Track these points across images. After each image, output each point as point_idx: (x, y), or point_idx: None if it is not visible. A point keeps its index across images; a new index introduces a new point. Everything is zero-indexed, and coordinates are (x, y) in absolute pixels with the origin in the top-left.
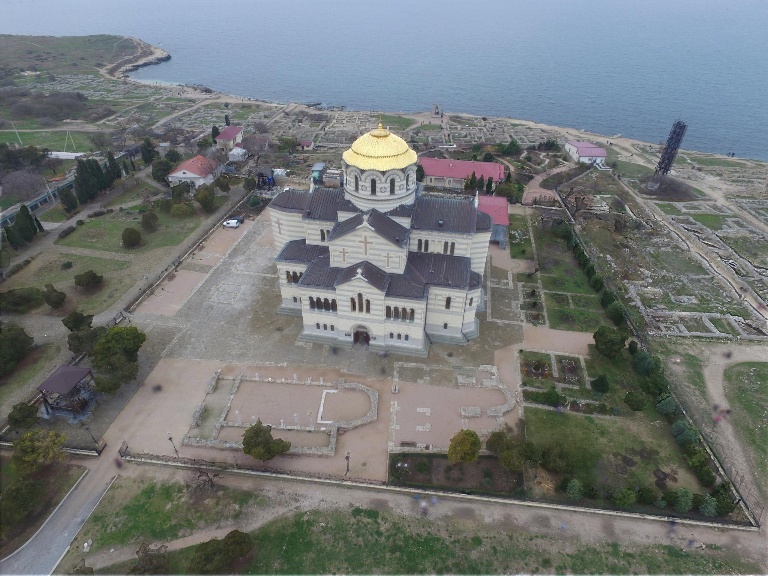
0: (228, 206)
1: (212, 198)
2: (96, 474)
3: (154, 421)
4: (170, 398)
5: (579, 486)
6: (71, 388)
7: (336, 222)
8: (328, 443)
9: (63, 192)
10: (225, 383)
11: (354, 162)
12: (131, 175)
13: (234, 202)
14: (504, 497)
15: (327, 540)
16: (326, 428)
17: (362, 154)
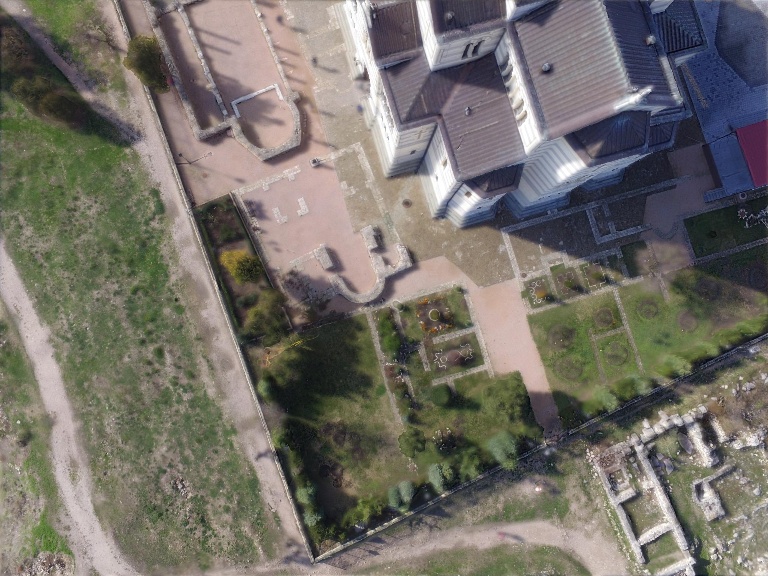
0: None
1: None
2: None
3: None
4: None
5: (262, 391)
6: None
7: None
8: None
9: None
10: None
11: None
12: None
13: None
14: (233, 322)
15: (119, 181)
16: None
17: None
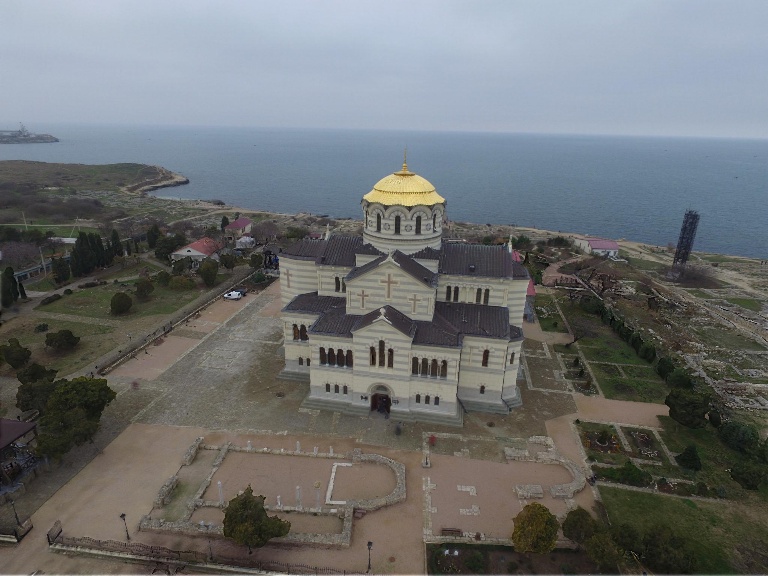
0: (231, 282)
1: (215, 271)
2: (7, 569)
3: (106, 498)
4: (133, 470)
5: None
6: (3, 445)
7: (354, 267)
8: (340, 530)
9: (57, 261)
10: (207, 453)
11: (377, 199)
12: (133, 256)
13: (238, 279)
14: None
15: None
16: (338, 509)
17: (386, 191)
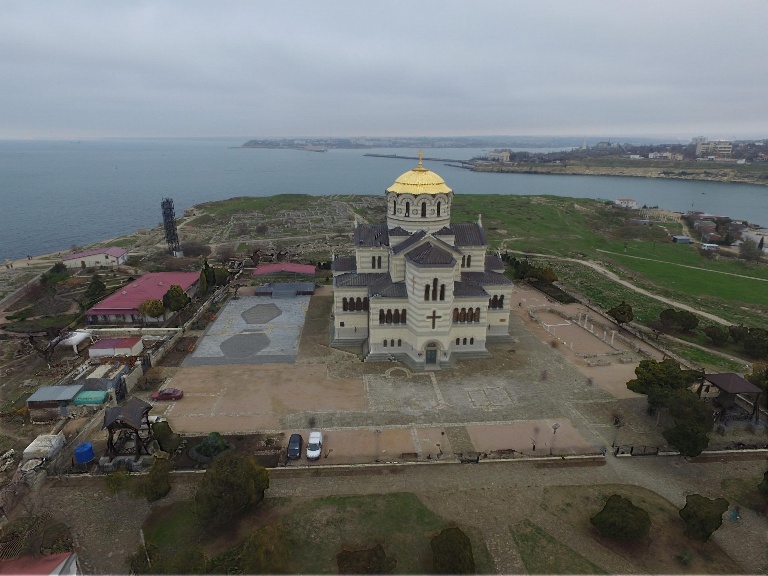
0: None
1: None
2: None
3: None
4: None
5: None
6: None
7: None
8: None
9: None
10: None
11: (446, 190)
12: None
13: (195, 486)
14: None
15: None
16: None
17: None
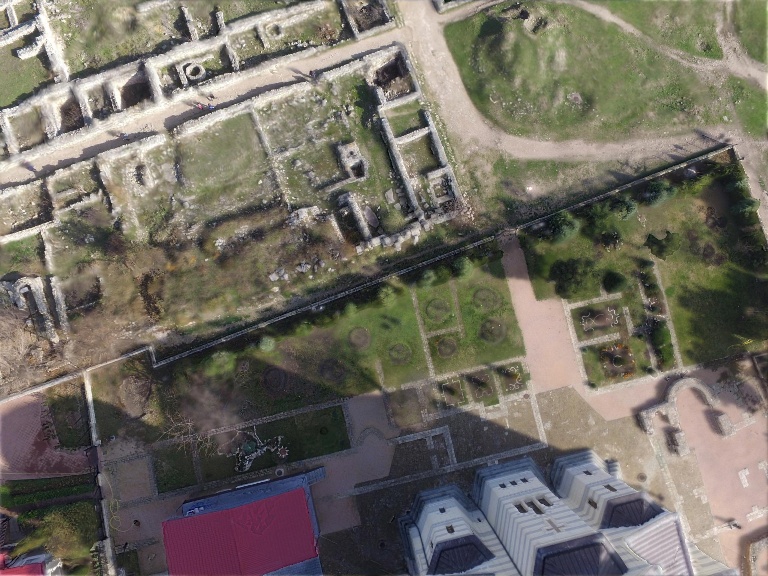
0: None
1: None
2: None
3: None
4: None
5: None
6: None
7: None
8: None
9: None
10: None
11: None
12: None
13: None
14: None
15: None
16: None
17: None
